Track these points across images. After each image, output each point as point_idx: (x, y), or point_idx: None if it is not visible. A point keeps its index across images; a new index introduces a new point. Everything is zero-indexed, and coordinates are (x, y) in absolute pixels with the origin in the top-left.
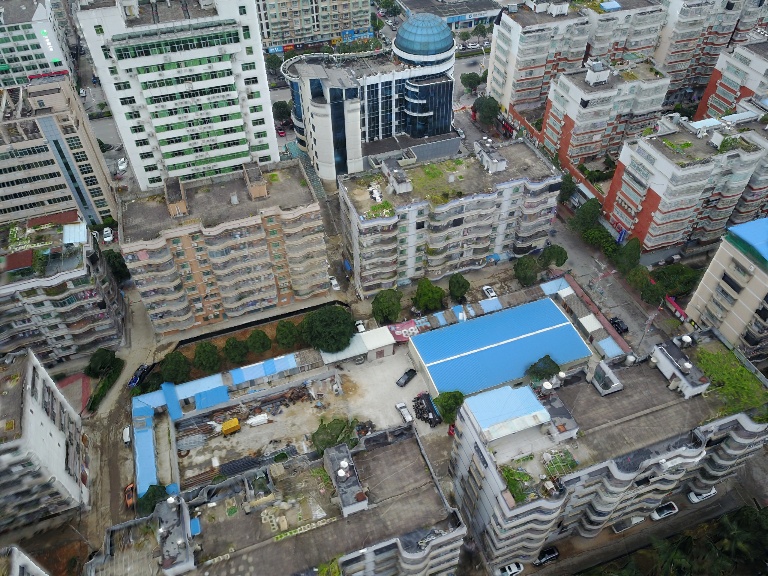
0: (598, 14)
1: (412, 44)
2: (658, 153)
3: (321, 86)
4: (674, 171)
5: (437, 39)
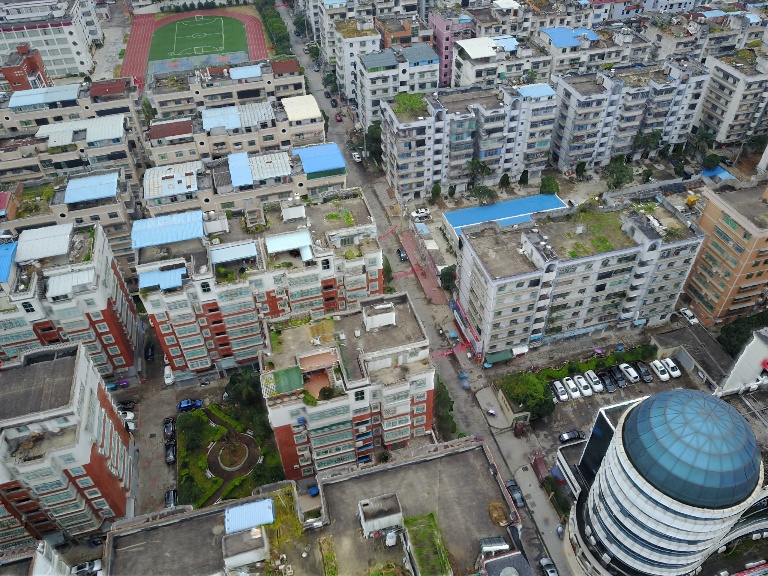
0: None
1: None
2: None
3: None
4: None
5: None
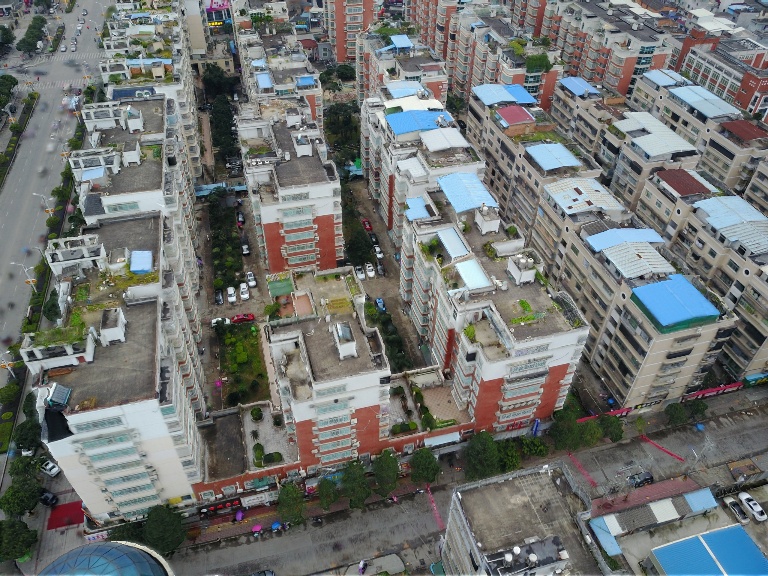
0: (158, 283)
1: None
2: (552, 337)
3: None
4: (581, 334)
5: None
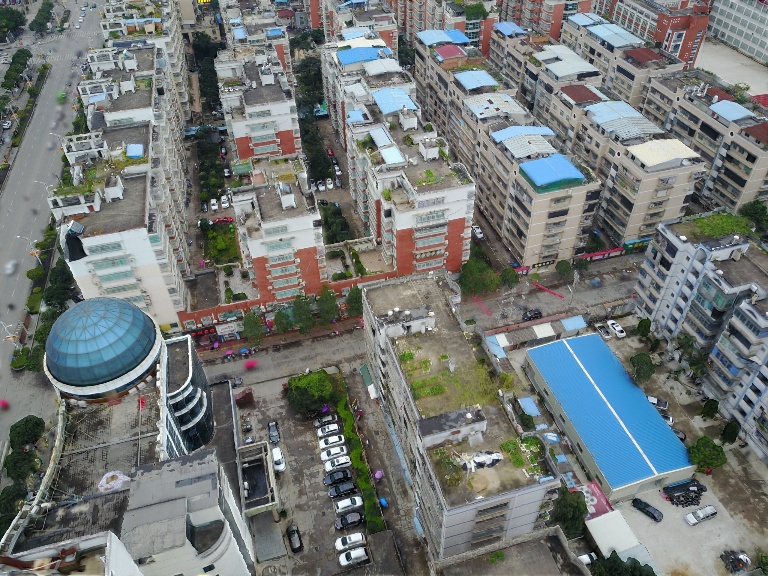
0: (147, 164)
1: (127, 354)
2: (445, 191)
3: (189, 520)
4: (469, 190)
5: (140, 317)
